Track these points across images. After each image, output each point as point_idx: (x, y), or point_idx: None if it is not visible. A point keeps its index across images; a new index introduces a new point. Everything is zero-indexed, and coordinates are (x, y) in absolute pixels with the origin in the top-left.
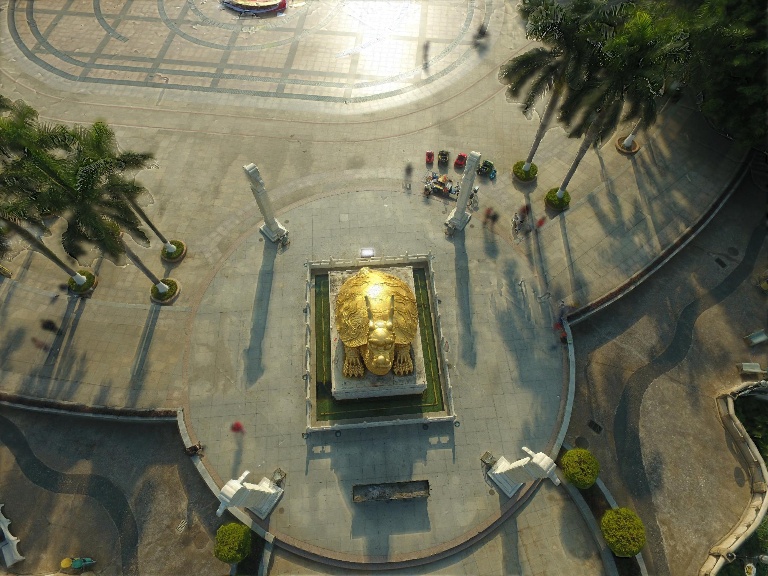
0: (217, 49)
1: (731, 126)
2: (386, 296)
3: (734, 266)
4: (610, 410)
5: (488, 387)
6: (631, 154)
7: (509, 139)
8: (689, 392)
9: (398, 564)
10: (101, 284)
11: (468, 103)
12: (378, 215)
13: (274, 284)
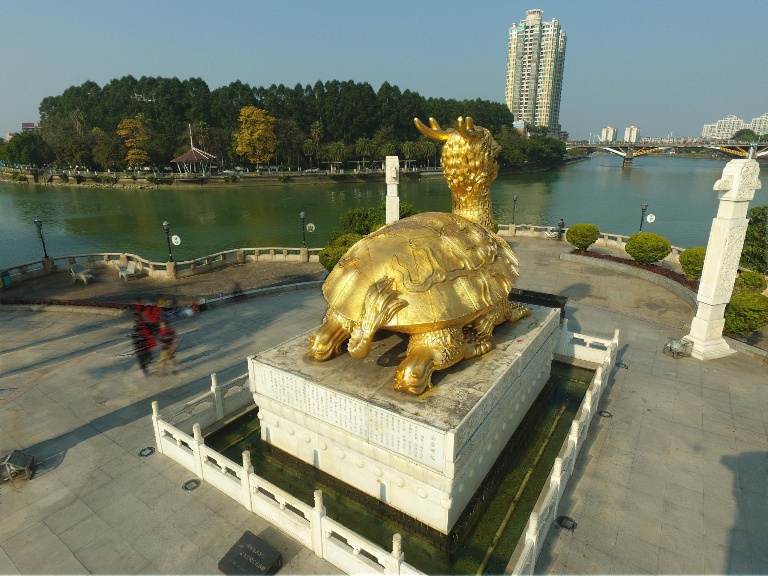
0: None
1: None
2: (397, 223)
3: None
4: None
5: None
6: None
7: None
8: None
9: None
10: None
11: None
12: None
13: None
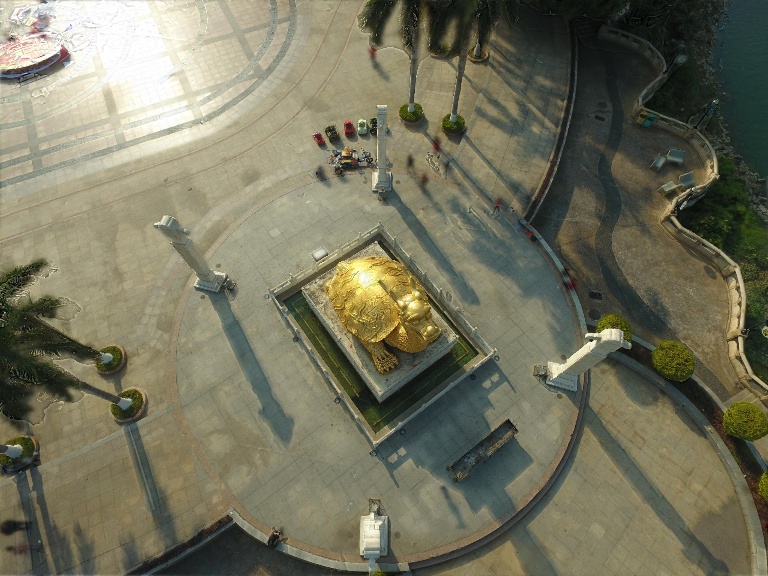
0: (15, 128)
1: (554, 2)
2: (383, 276)
3: (610, 116)
4: (597, 276)
5: (501, 312)
6: (485, 61)
7: (379, 91)
8: (641, 229)
9: (526, 508)
10: (44, 442)
11: (321, 75)
12: (306, 214)
13: (246, 332)
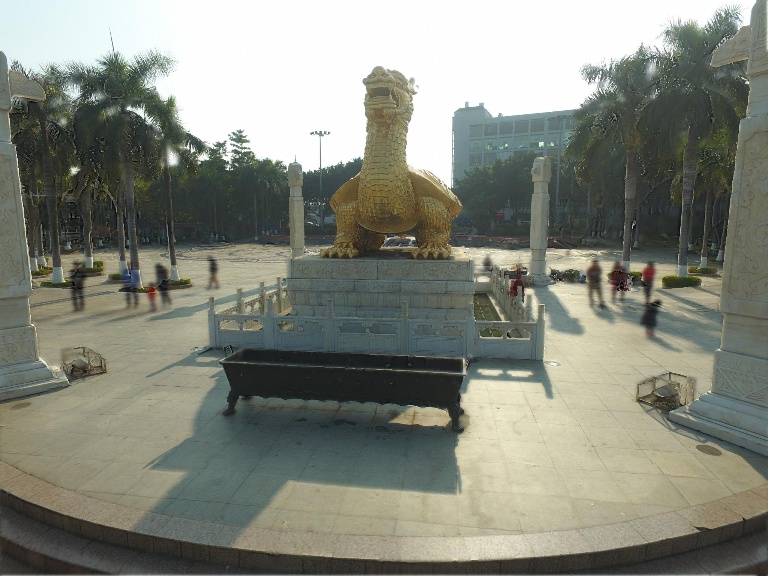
0: None
1: None
2: None
3: None
4: None
5: (622, 344)
6: None
7: None
8: None
9: None
10: None
11: None
12: None
13: None
